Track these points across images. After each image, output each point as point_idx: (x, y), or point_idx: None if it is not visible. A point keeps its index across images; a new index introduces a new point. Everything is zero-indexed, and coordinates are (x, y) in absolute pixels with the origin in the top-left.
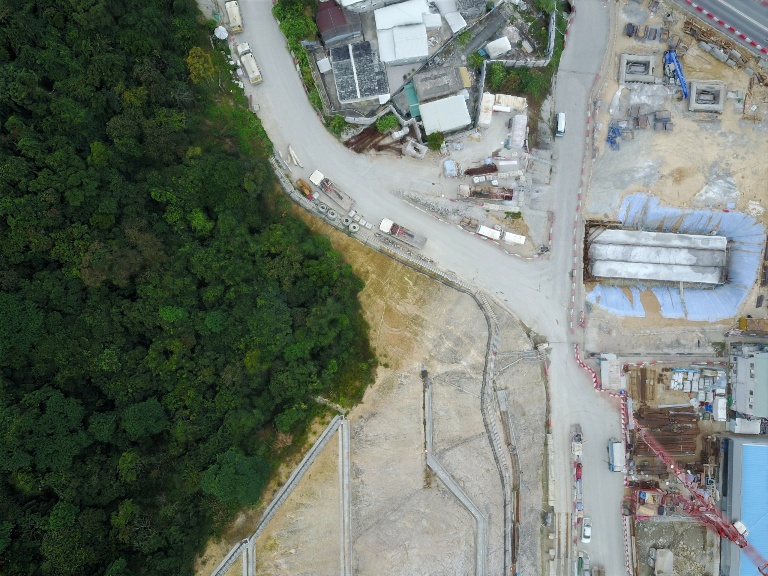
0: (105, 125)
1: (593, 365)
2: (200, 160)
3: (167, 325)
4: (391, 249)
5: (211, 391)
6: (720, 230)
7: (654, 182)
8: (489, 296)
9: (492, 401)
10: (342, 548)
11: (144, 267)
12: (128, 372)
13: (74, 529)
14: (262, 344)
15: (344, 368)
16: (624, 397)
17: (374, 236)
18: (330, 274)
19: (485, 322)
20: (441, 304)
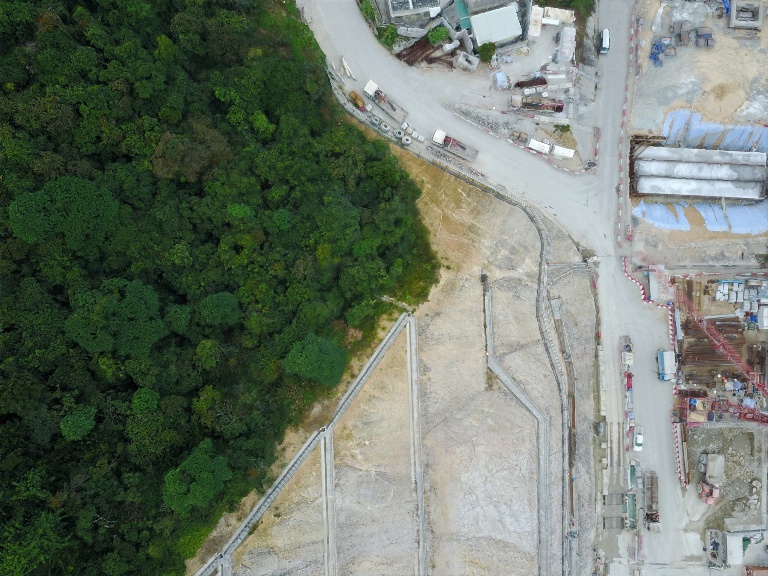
0: (168, 24)
1: (641, 278)
2: (261, 62)
3: (237, 220)
4: (443, 162)
5: (281, 286)
6: (759, 147)
7: (696, 98)
8: (538, 210)
9: (546, 310)
10: (412, 443)
11: (211, 165)
12: (199, 267)
13: (156, 414)
14: (331, 239)
15: (408, 268)
16: (672, 308)
17: (426, 149)
18: (393, 175)
19: (537, 233)
20: (494, 215)
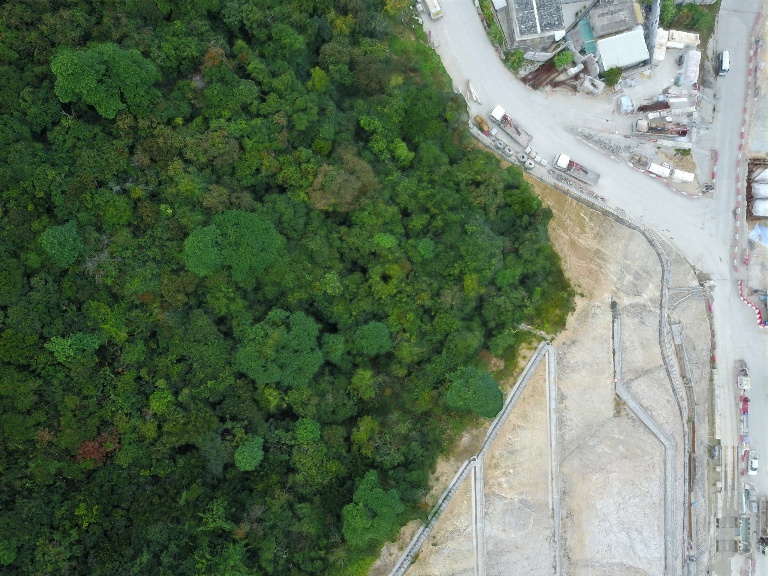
0: (314, 54)
1: (756, 302)
2: (401, 90)
3: (385, 250)
4: (564, 186)
5: (427, 316)
6: None
7: None
8: (656, 234)
9: (668, 335)
10: (550, 471)
11: None
12: (348, 296)
13: (320, 444)
14: (477, 269)
15: (544, 296)
16: None
17: (548, 173)
18: (530, 203)
19: (657, 258)
20: (616, 240)
